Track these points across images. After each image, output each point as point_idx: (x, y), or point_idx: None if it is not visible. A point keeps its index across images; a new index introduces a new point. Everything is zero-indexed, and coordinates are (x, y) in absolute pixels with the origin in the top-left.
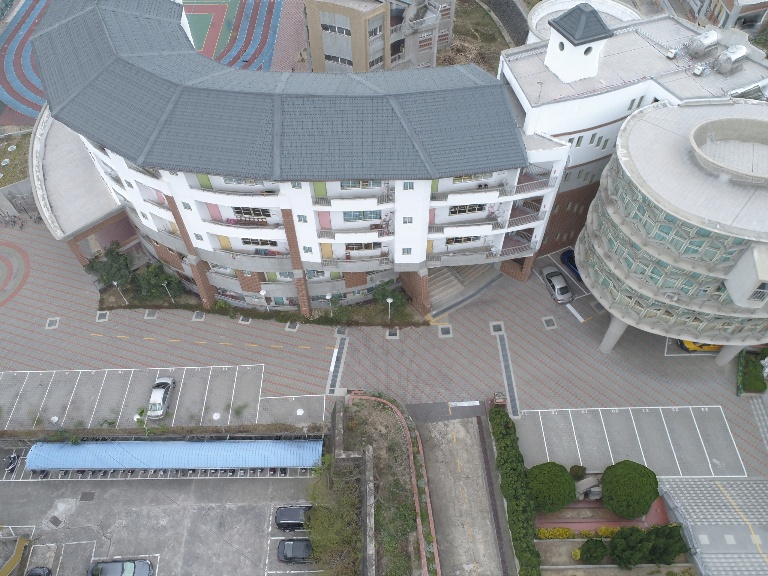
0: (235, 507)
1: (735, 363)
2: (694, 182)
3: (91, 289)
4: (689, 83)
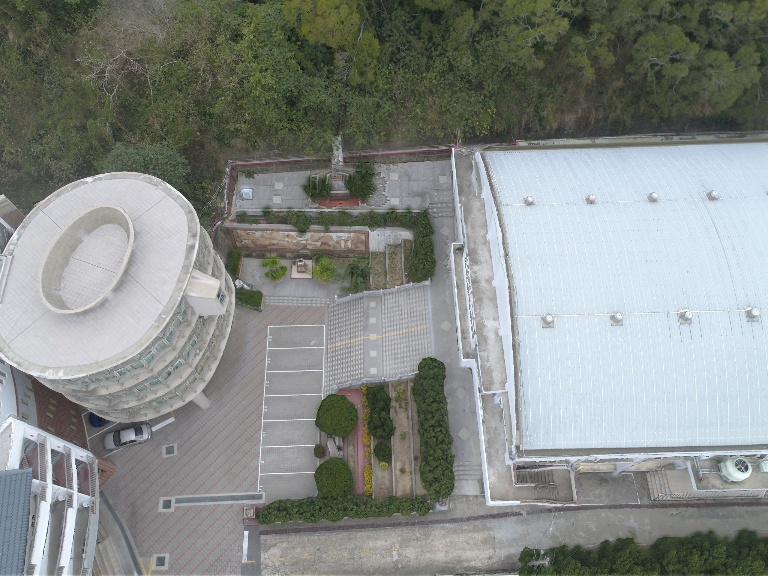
0: None
1: (235, 305)
2: (108, 321)
3: None
4: None
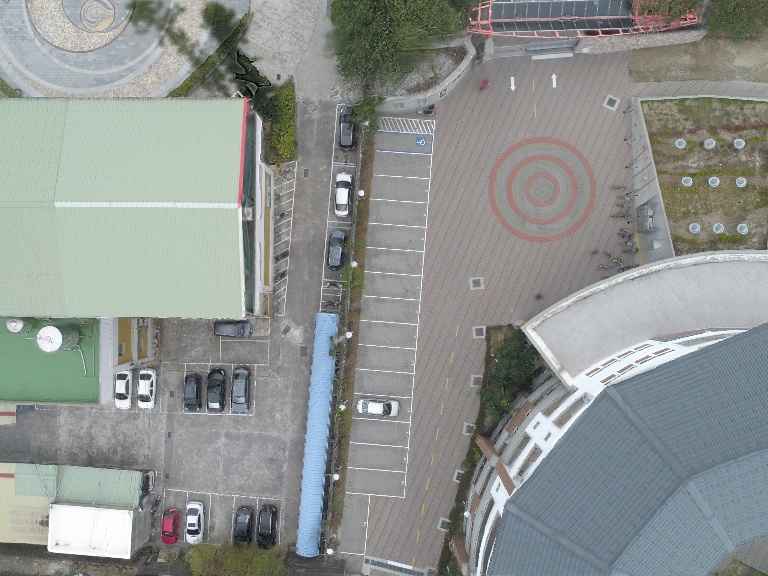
0: (284, 471)
1: None
2: None
3: (516, 314)
4: None
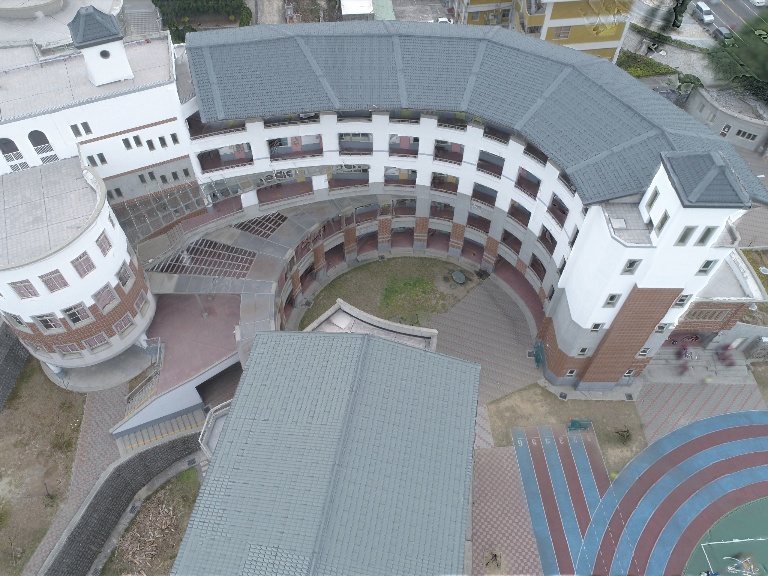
0: None
1: None
2: None
3: None
4: (5, 63)
